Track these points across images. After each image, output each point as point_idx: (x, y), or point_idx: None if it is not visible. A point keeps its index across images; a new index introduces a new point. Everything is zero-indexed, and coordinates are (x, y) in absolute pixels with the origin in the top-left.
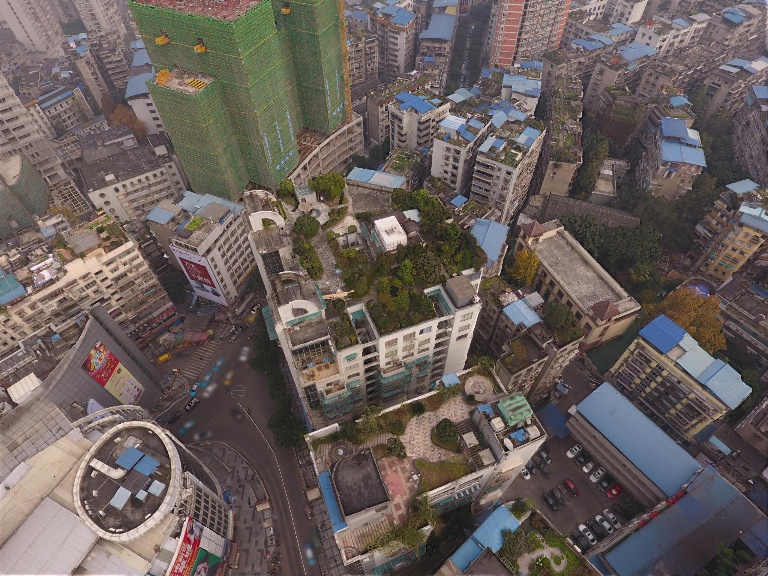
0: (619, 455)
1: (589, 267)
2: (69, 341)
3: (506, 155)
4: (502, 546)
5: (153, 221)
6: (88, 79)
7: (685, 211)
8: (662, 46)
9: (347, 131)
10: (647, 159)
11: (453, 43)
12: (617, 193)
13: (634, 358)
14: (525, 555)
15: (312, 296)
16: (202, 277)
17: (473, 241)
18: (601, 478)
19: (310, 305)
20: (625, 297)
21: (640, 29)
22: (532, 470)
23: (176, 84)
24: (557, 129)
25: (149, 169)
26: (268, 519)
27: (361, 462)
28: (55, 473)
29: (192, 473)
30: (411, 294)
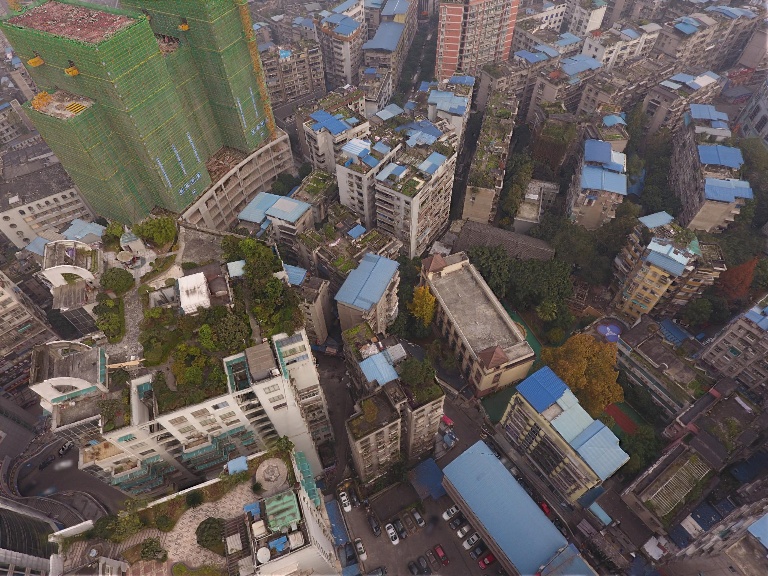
0: (483, 526)
1: (490, 305)
2: None
3: (406, 183)
4: None
5: (33, 252)
6: (25, 91)
7: (602, 243)
8: (609, 58)
9: (272, 149)
10: (574, 183)
11: (406, 52)
12: (540, 220)
13: (515, 413)
14: None
15: (91, 367)
16: None
17: (291, 300)
18: (475, 545)
19: (76, 381)
20: (520, 341)
21: (587, 40)
22: (402, 534)
23: (54, 108)
24: (482, 150)
25: (58, 190)
26: None
27: None
28: None
29: (5, 544)
30: (207, 364)
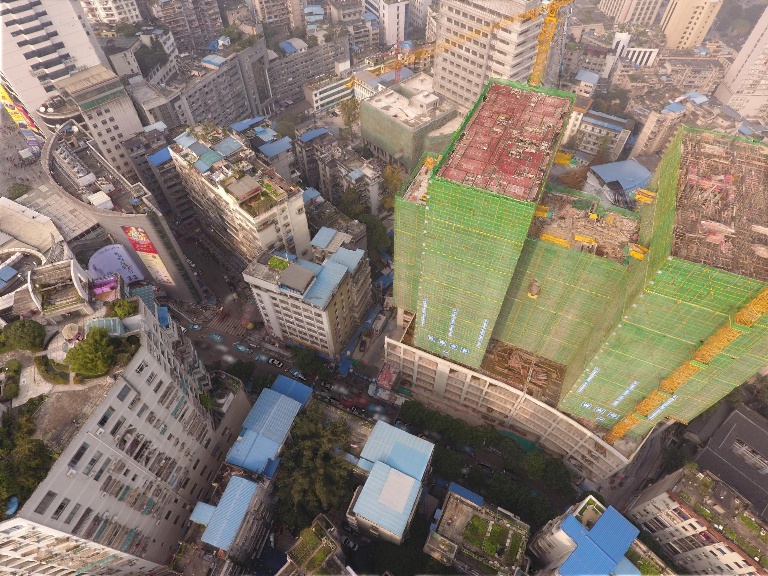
0: None
1: None
2: (134, 210)
3: None
4: None
5: None
6: (644, 133)
7: None
8: None
9: None
10: None
11: None
12: None
13: None
14: None
15: None
16: None
17: None
18: None
19: None
20: None
21: None
22: None
23: None
24: None
25: None
26: None
27: None
28: (33, 237)
29: None
30: None
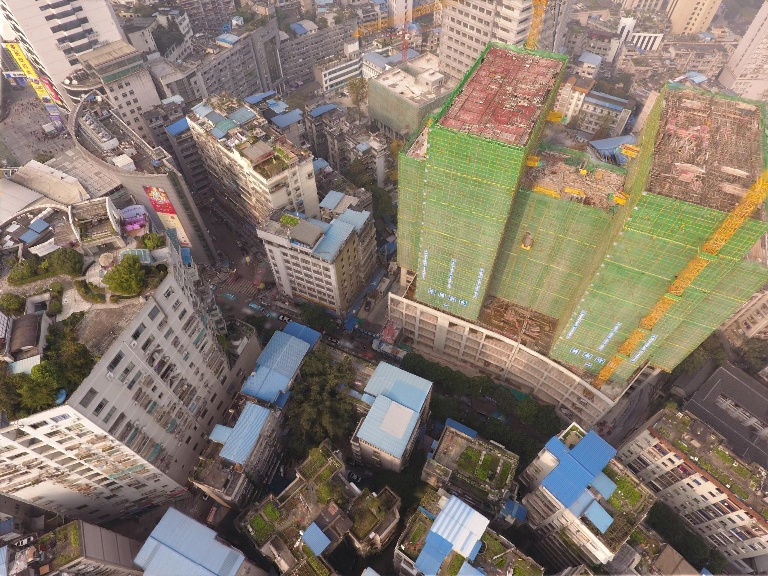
0: None
1: None
2: (155, 171)
3: None
4: None
5: None
6: (644, 112)
7: None
8: None
9: None
10: None
11: None
12: None
13: None
14: None
15: None
16: None
17: None
18: None
19: None
20: None
21: None
22: None
23: None
24: None
25: None
26: None
27: None
28: (61, 196)
29: None
30: None
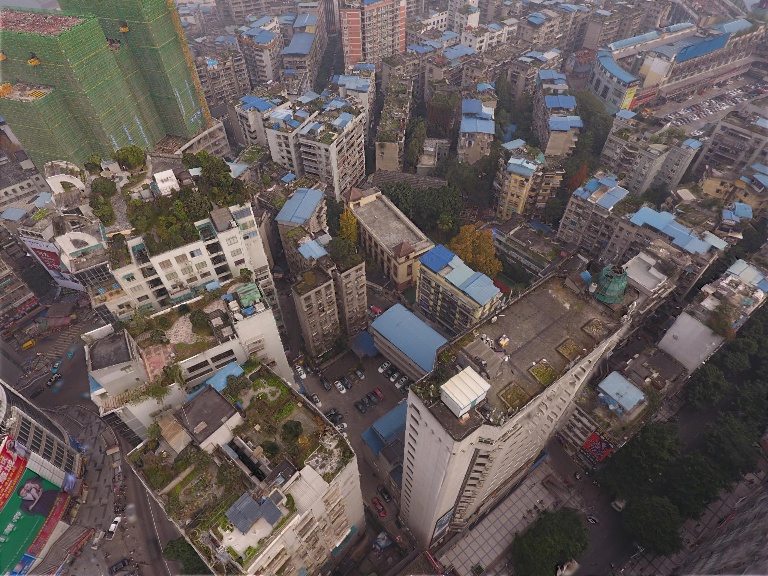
0: (404, 356)
1: (400, 221)
2: None
3: (324, 136)
4: (226, 386)
5: (6, 219)
6: None
7: (481, 171)
8: (482, 47)
9: (210, 136)
10: None
11: (320, 59)
12: (437, 165)
13: (422, 283)
14: (250, 394)
15: (95, 233)
16: (57, 265)
17: (239, 184)
18: (404, 384)
19: (87, 237)
20: (424, 240)
21: (462, 34)
22: (347, 386)
23: (18, 95)
24: (385, 117)
25: (15, 182)
26: (117, 461)
27: (115, 340)
28: None
29: (24, 412)
30: (183, 226)
